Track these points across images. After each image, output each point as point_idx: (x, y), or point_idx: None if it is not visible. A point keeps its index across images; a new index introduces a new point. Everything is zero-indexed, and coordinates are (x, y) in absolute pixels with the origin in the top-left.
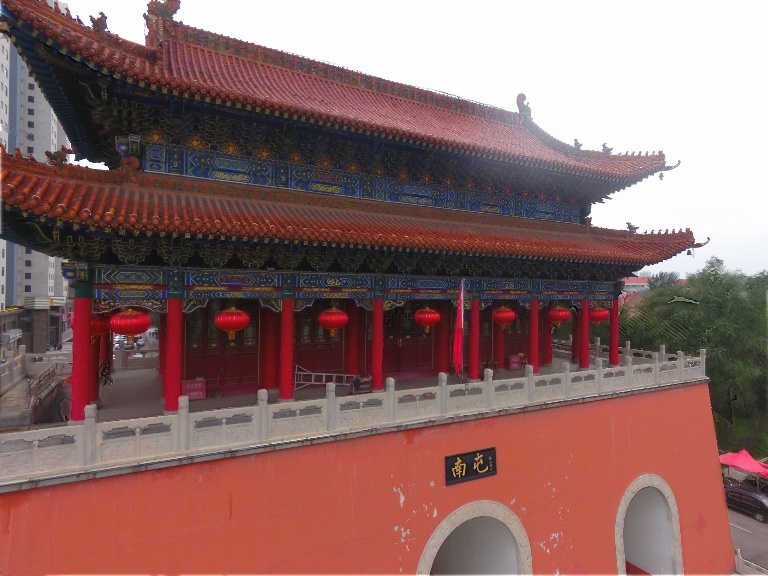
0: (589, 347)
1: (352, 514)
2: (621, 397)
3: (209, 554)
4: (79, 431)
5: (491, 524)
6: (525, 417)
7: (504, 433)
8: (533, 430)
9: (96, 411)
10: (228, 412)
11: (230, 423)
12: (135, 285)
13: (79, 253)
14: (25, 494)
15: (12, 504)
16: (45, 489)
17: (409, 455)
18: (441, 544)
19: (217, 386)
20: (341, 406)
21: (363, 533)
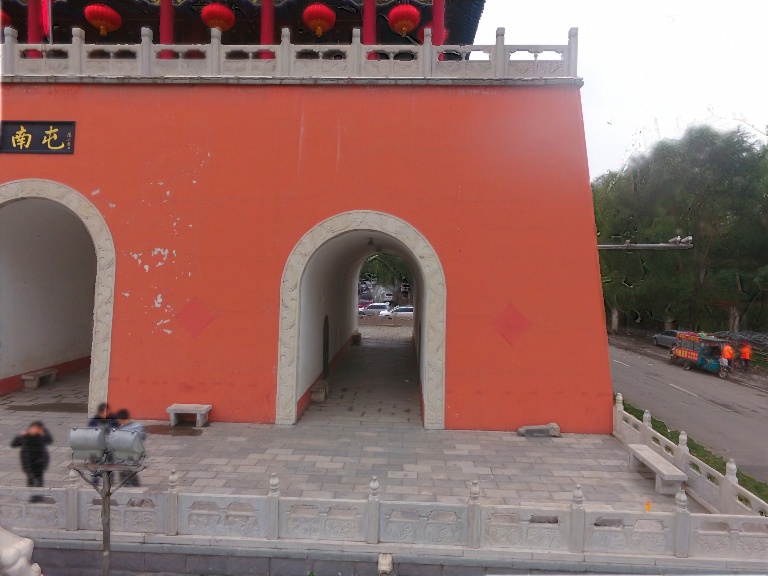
0: None
1: None
2: (327, 87)
3: None
4: None
5: None
6: (130, 93)
7: (93, 108)
8: (142, 111)
9: None
10: None
11: None
12: None
13: None
14: None
15: None
16: None
17: None
18: None
19: None
20: None
21: None
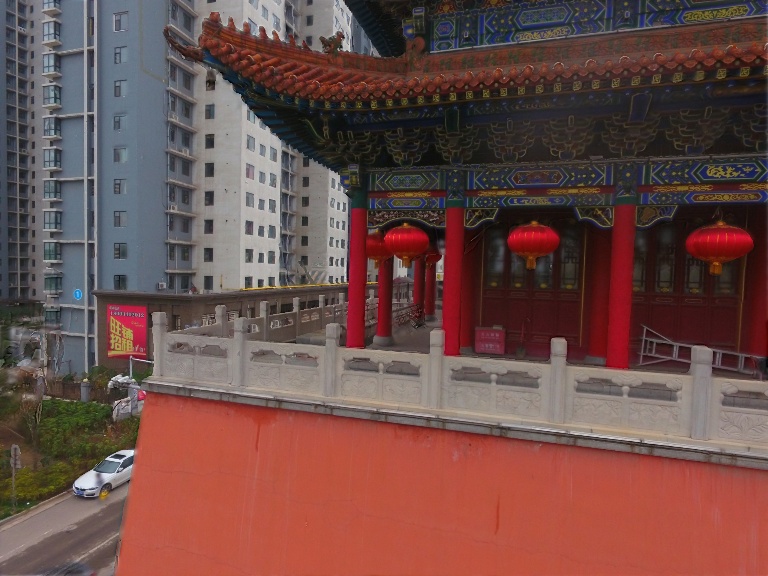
0: None
1: None
2: None
3: (462, 573)
4: (321, 353)
5: None
6: None
7: None
8: None
9: (337, 332)
10: (500, 365)
11: (503, 383)
12: (410, 192)
13: (353, 155)
14: (272, 413)
15: (261, 420)
16: (288, 413)
17: None
18: None
19: (520, 341)
20: (726, 397)
21: None
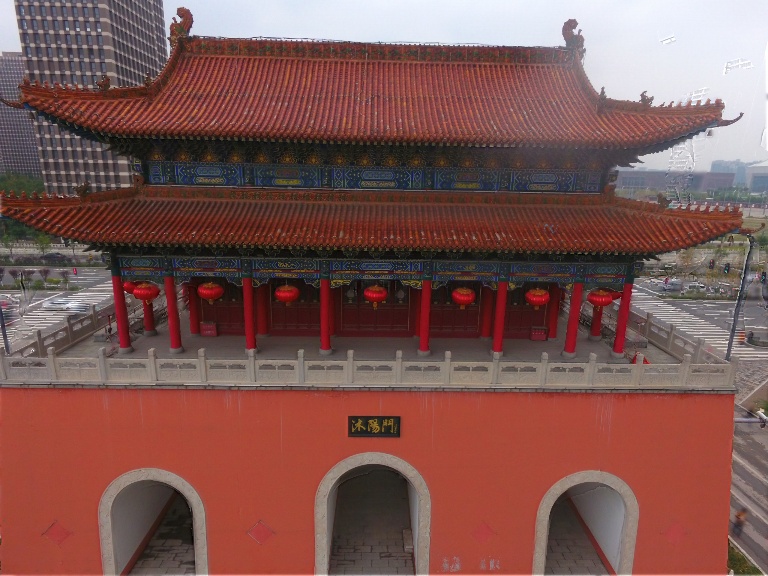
0: (158, 297)
1: None
2: None
3: None
4: None
5: None
6: None
7: None
8: None
9: None
10: None
11: None
12: None
13: None
14: None
15: None
16: None
17: None
18: None
19: None
20: None
21: None
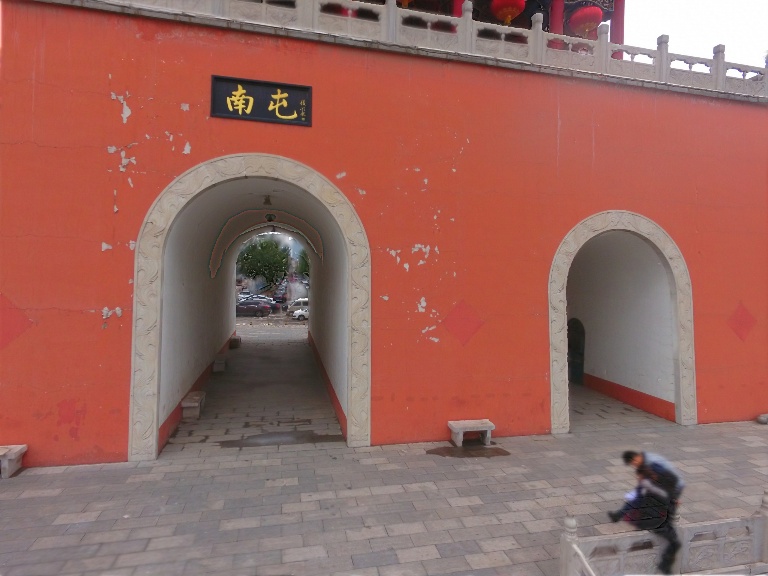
0: None
1: (33, 108)
2: (580, 81)
3: None
4: None
5: (336, 238)
6: (376, 61)
7: (332, 73)
8: (391, 84)
9: None
10: None
11: None
12: None
13: None
14: None
15: None
16: None
17: (146, 57)
18: (194, 195)
19: None
20: None
21: (52, 140)
